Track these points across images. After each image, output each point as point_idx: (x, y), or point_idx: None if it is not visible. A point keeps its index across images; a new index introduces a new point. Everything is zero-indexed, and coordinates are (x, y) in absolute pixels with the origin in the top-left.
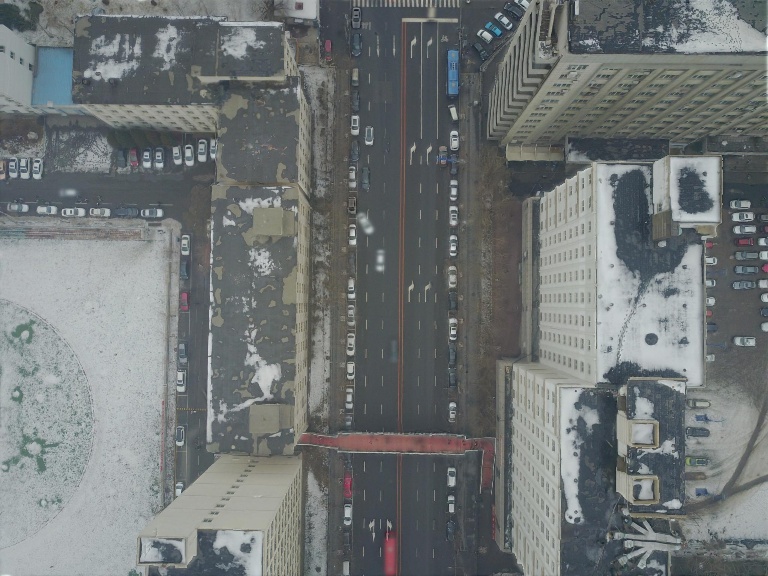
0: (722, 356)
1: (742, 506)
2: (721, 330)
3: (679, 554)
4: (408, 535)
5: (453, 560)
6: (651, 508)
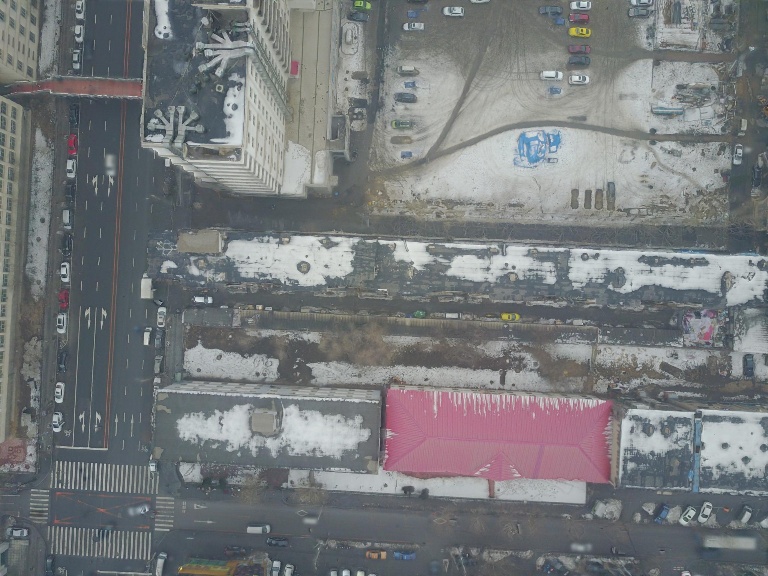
0: (432, 27)
1: (445, 169)
2: (432, 2)
3: (383, 213)
4: (129, 191)
5: (170, 215)
6: (214, 1)
